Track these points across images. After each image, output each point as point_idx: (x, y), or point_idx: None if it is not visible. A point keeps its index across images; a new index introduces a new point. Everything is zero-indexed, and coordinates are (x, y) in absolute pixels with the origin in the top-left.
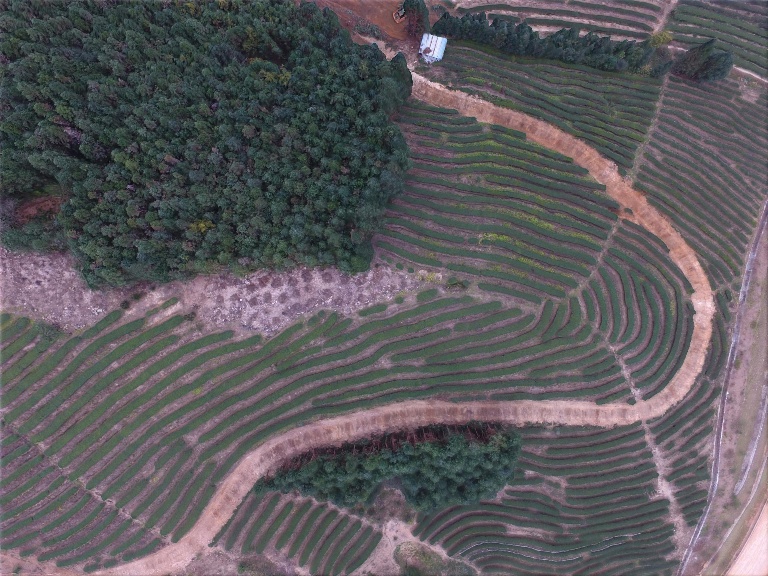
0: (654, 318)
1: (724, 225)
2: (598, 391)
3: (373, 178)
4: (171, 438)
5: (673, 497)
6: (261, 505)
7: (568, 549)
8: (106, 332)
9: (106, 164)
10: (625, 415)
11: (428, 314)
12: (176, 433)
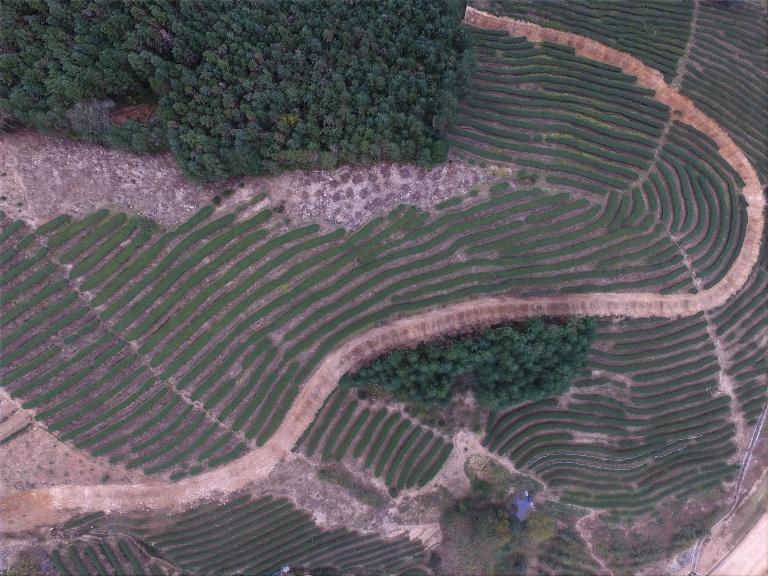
0: (711, 209)
1: (766, 127)
2: (662, 280)
3: (450, 70)
4: (259, 335)
5: (734, 394)
6: (340, 411)
7: (633, 455)
8: (198, 228)
9: (197, 65)
10: (688, 306)
11: (500, 207)
12: (264, 330)
